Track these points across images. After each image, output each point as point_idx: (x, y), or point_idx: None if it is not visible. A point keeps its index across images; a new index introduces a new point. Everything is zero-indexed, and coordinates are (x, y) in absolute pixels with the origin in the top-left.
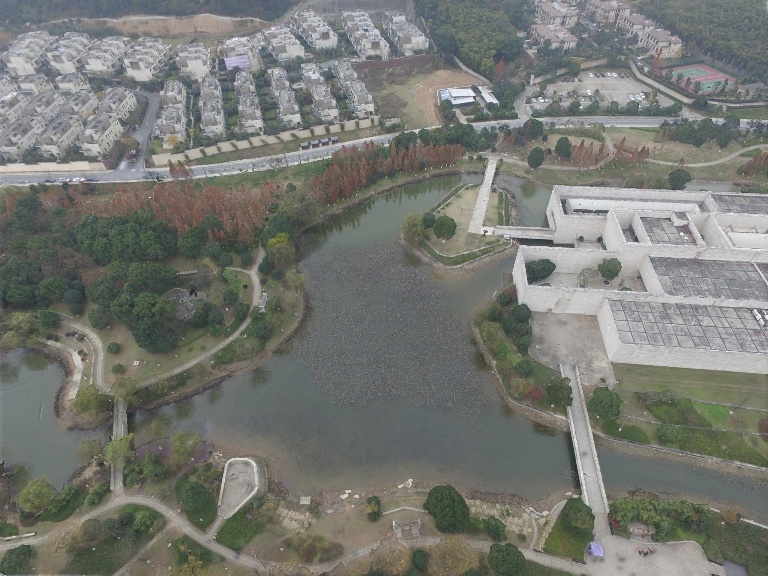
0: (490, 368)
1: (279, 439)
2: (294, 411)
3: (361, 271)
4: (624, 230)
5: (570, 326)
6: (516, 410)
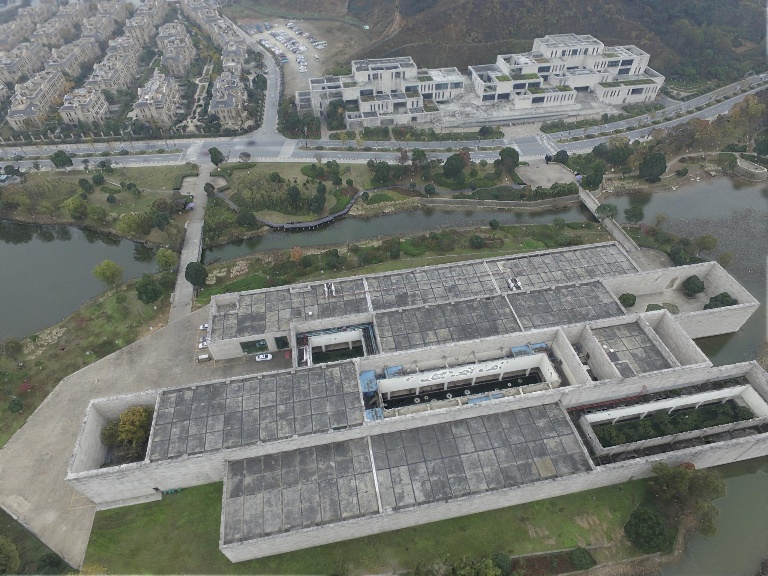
0: None
1: (757, 190)
2: (767, 202)
3: None
4: None
5: None
6: None
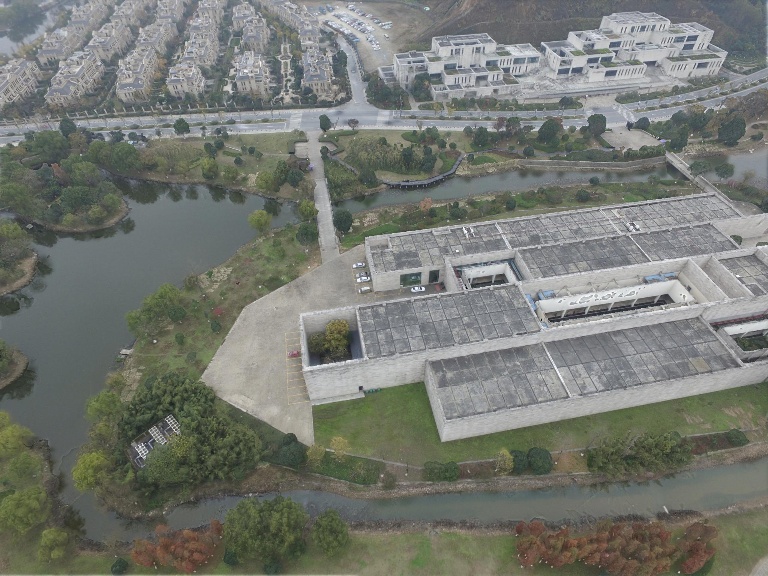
0: None
1: None
2: None
3: None
4: None
5: None
6: None
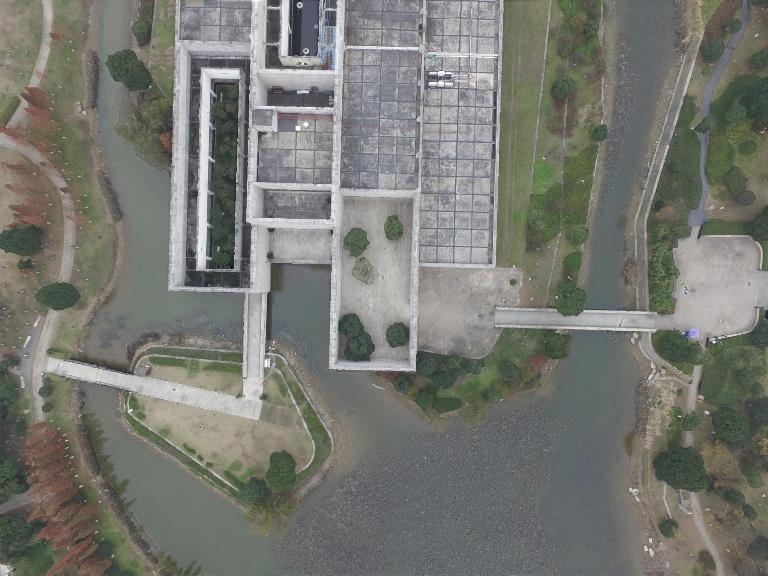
0: (496, 403)
1: None
2: None
3: (345, 571)
4: (265, 197)
5: (435, 303)
6: (548, 379)
